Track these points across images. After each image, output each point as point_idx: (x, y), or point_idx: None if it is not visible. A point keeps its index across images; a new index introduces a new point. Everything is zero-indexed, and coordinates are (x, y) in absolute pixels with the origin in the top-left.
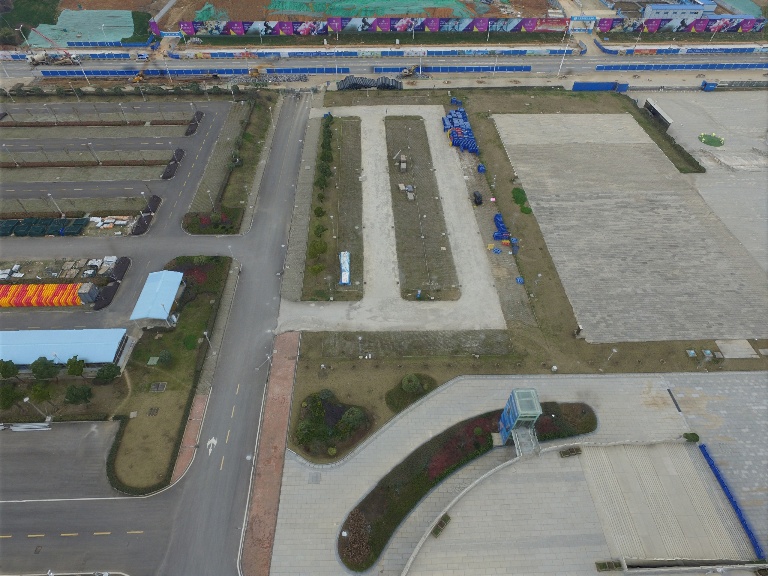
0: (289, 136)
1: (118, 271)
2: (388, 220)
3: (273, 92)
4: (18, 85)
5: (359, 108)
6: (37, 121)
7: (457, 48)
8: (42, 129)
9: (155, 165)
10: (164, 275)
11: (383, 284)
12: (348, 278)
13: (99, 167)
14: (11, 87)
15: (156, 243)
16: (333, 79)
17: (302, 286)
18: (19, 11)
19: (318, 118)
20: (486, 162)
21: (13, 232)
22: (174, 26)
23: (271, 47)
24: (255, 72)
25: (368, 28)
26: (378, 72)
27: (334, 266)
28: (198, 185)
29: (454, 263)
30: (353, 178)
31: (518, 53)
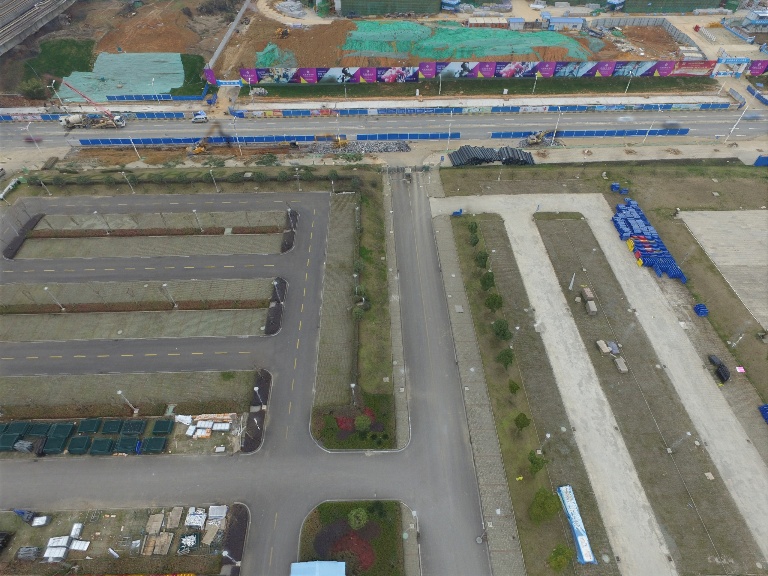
0: (416, 249)
1: (234, 540)
2: (604, 413)
3: (374, 171)
4: (52, 160)
5: (494, 199)
6: (83, 230)
7: (580, 99)
8: (90, 241)
9: (251, 308)
10: (318, 573)
11: (647, 562)
12: (590, 550)
13: (174, 311)
14: (43, 163)
15: (279, 470)
16: (441, 148)
17: (525, 571)
18: (48, 56)
19: (445, 216)
20: (702, 297)
21: (67, 449)
22: (231, 72)
23: (352, 99)
24: (342, 139)
25: (467, 74)
26: (495, 137)
27: (558, 519)
28: (317, 346)
29: (739, 510)
30: (526, 327)
31: (661, 108)
